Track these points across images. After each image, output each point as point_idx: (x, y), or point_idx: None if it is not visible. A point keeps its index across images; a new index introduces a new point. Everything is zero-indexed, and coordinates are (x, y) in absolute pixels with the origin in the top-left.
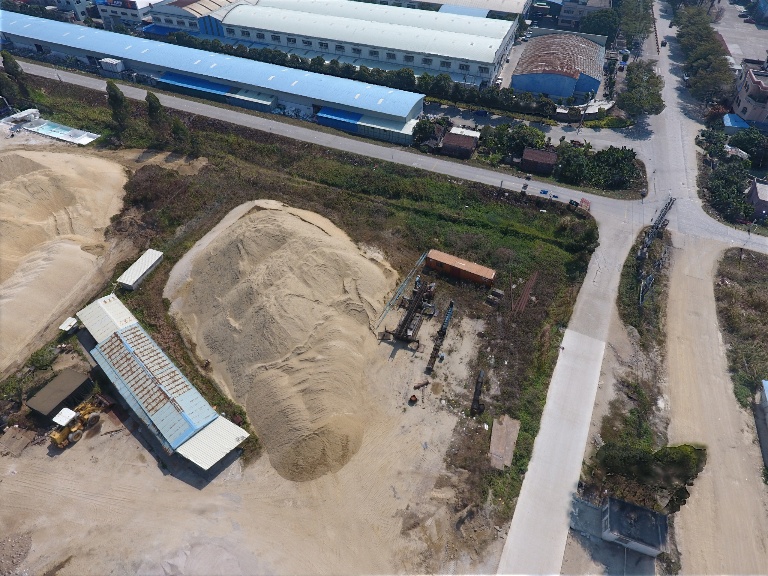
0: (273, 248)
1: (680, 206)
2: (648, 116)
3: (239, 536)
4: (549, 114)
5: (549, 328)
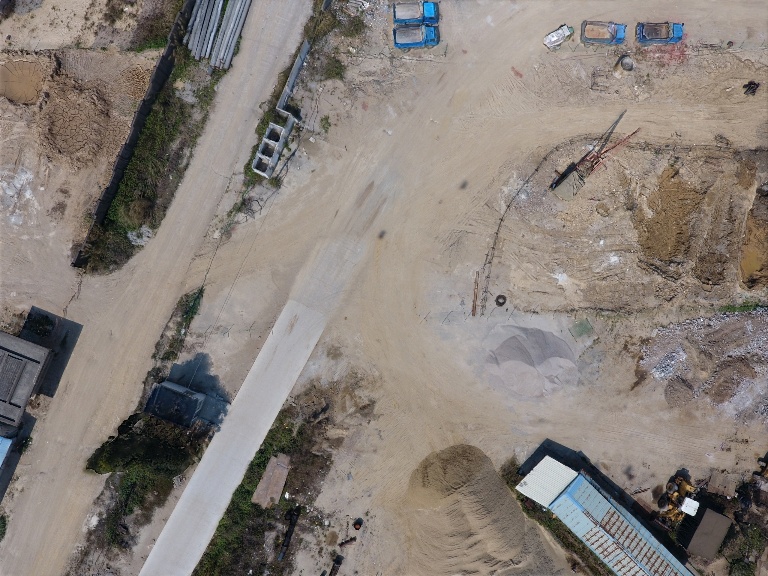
0: None
1: None
2: None
3: (507, 402)
4: None
5: None
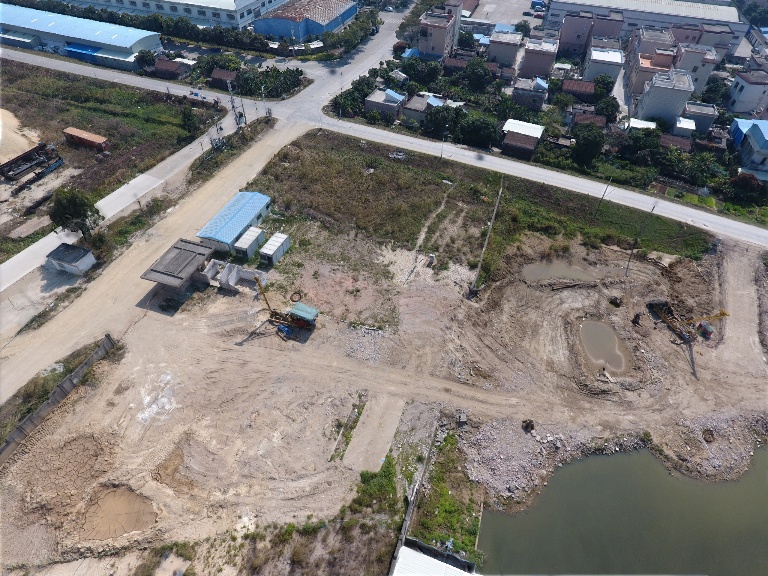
0: None
1: (306, 105)
2: (359, 53)
3: None
4: (258, 47)
5: (122, 171)
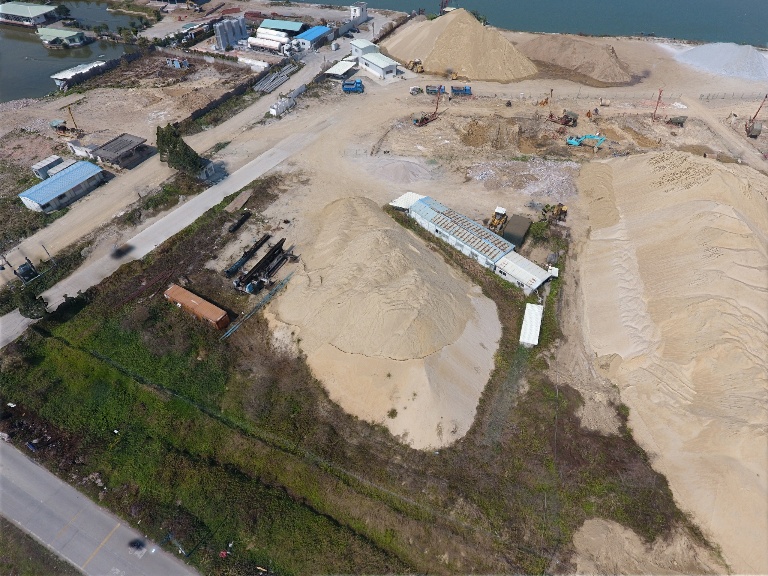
0: (387, 285)
1: None
2: None
3: (388, 183)
4: None
5: None
